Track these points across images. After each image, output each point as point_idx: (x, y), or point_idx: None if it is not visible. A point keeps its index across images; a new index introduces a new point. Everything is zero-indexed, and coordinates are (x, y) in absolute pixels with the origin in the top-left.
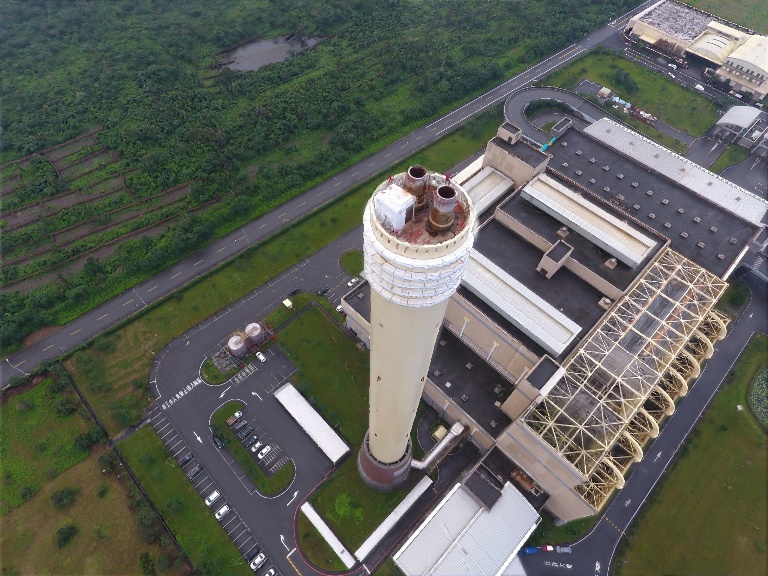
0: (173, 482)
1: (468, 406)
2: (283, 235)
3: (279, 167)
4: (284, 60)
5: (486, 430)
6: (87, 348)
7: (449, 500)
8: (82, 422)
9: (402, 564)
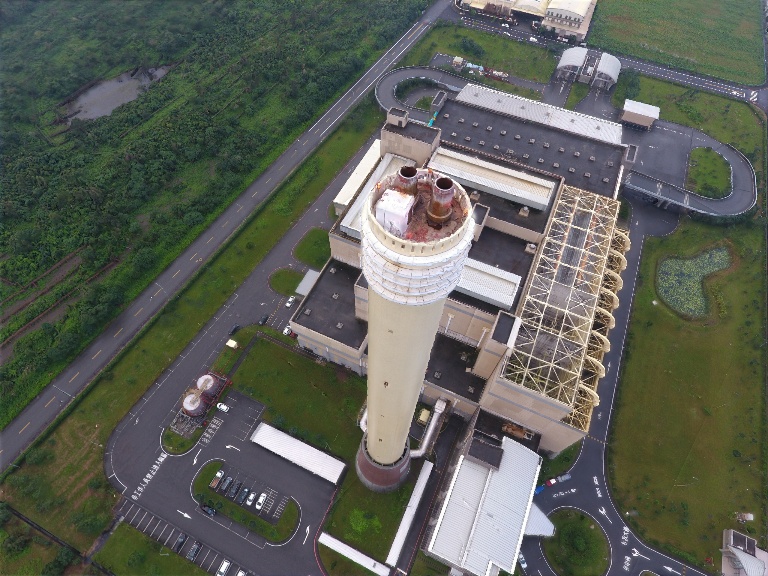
0: (174, 571)
1: (443, 382)
2: (201, 277)
3: (172, 209)
4: (137, 97)
5: (467, 398)
6: (18, 468)
7: (459, 475)
8: (42, 551)
9: (439, 552)
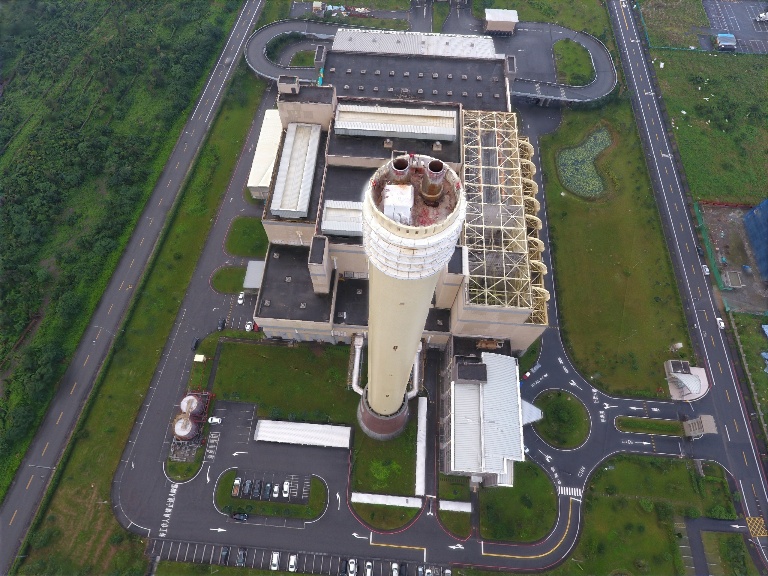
0: None
1: None
2: (139, 303)
3: (77, 243)
4: None
5: (438, 331)
6: (26, 557)
7: (455, 399)
8: None
9: (460, 468)
